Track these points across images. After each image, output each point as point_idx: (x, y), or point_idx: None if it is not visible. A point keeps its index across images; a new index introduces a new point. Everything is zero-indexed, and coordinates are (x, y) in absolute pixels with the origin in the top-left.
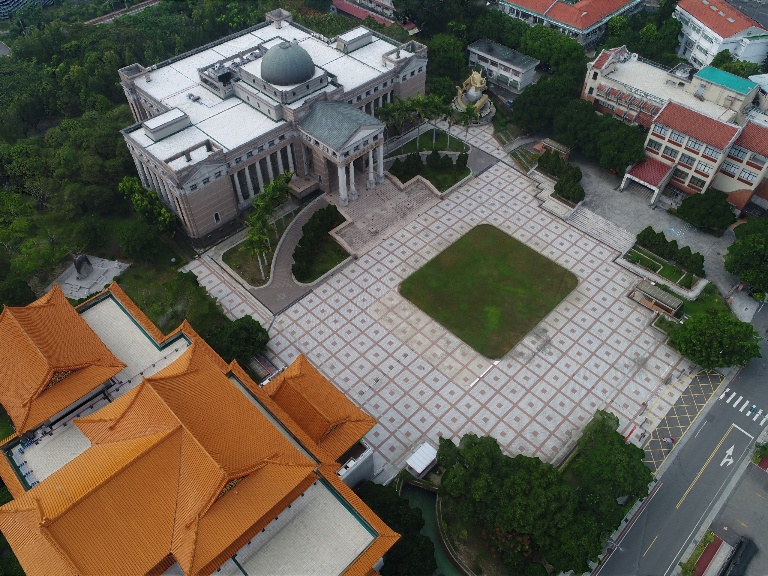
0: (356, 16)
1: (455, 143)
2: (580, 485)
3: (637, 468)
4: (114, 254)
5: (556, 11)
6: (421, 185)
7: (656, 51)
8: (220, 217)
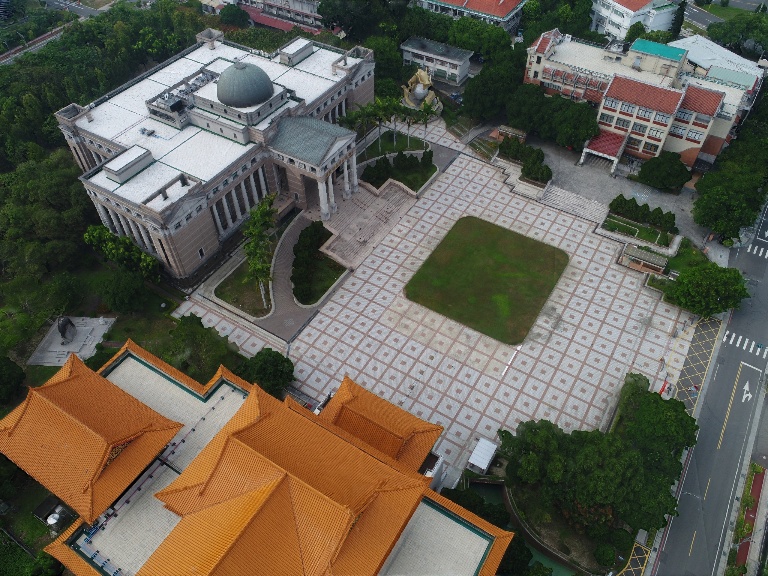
0: (277, 28)
1: (413, 142)
2: (636, 447)
3: (685, 420)
4: (94, 310)
5: (474, 2)
6: (394, 188)
7: (577, 30)
8: (204, 252)
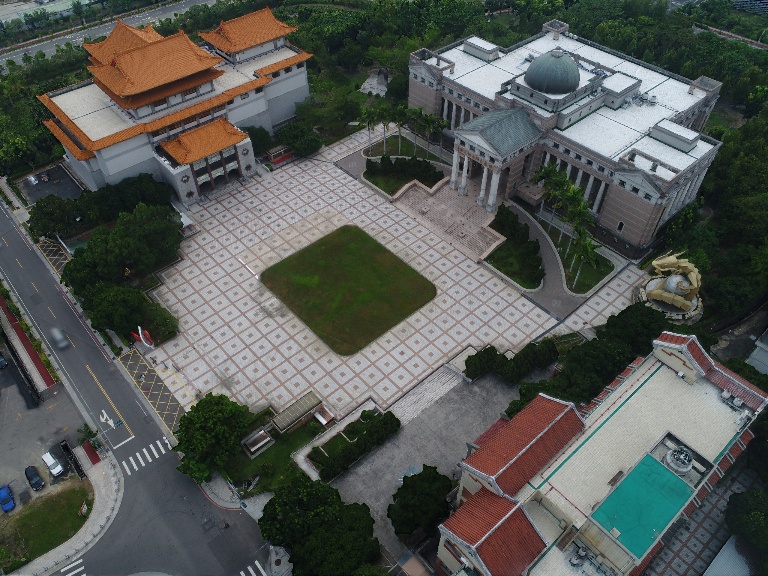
0: None
1: None
2: None
3: None
4: None
5: None
6: None
7: None
8: None
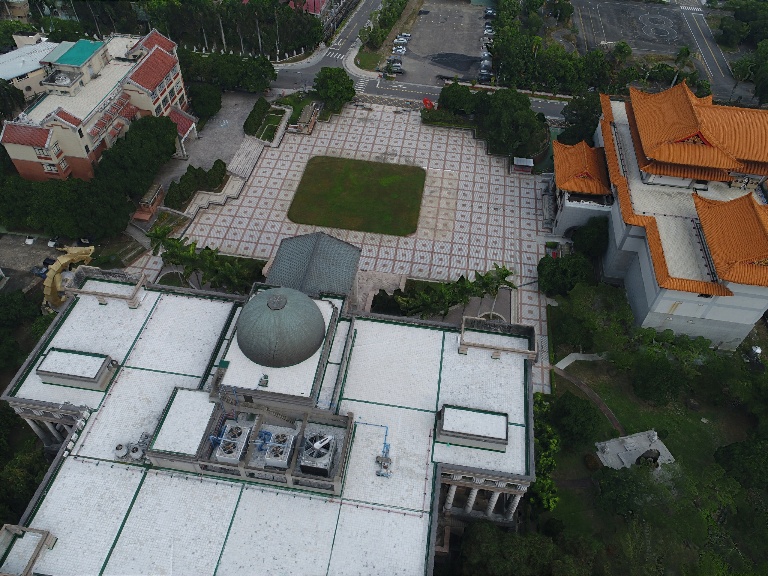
0: None
1: None
2: (478, 106)
3: None
4: None
5: None
6: None
7: None
8: None
